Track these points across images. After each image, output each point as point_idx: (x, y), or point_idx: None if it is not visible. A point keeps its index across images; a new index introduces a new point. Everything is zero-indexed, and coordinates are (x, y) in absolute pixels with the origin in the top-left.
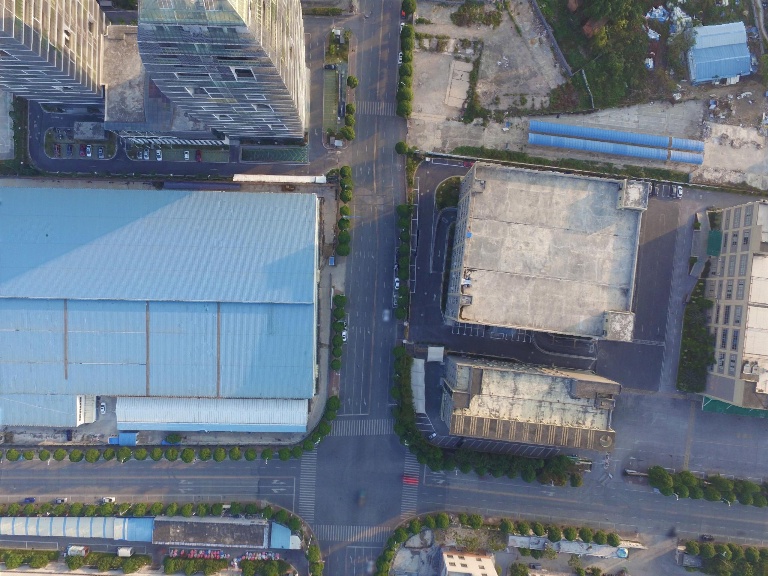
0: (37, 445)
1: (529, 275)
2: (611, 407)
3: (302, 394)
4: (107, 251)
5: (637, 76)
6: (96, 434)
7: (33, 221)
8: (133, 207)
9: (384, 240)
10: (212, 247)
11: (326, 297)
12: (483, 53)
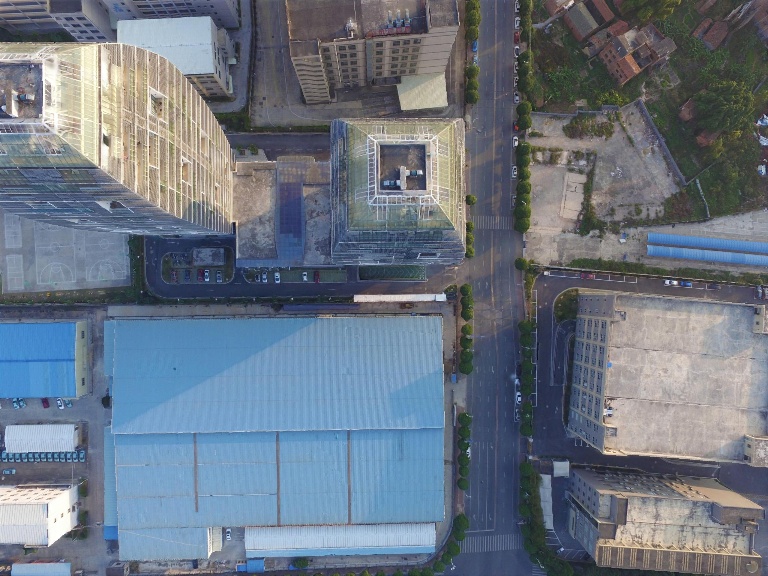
0: (163, 575)
1: (669, 402)
2: (755, 531)
3: (433, 517)
4: (236, 383)
5: (750, 183)
6: (222, 561)
7: (160, 355)
8: (259, 337)
9: (504, 354)
10: (340, 375)
11: (448, 413)
12: (596, 164)
